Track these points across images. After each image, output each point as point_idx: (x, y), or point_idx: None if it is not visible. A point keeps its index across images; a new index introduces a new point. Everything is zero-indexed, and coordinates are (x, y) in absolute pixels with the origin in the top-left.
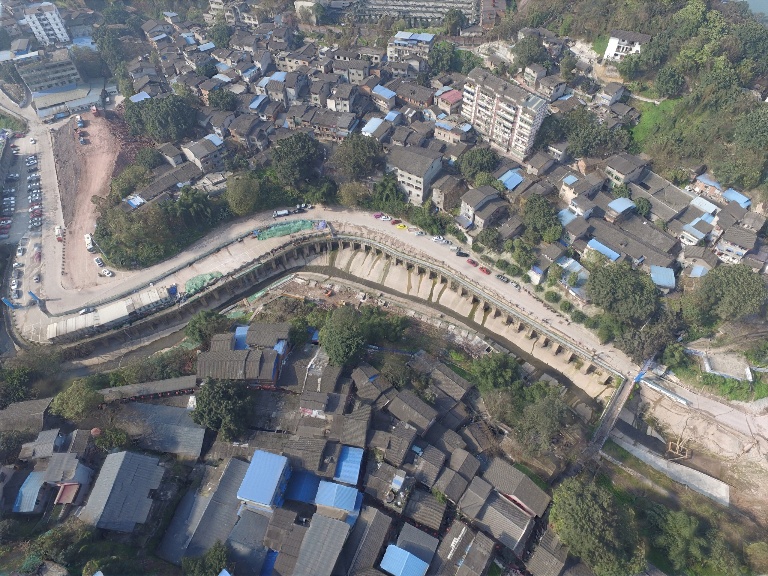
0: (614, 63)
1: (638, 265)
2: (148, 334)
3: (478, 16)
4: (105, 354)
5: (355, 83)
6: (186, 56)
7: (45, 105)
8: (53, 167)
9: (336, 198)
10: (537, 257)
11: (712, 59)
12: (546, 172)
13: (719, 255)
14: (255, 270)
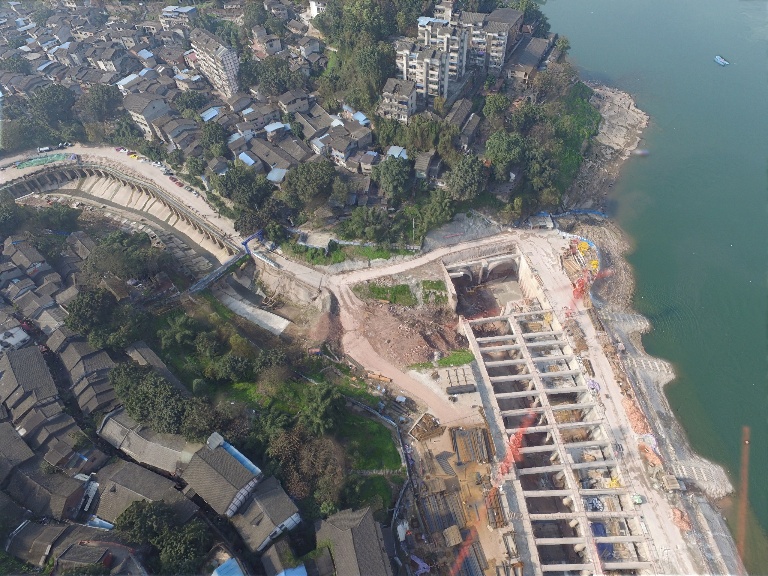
0: (311, 21)
1: None
2: None
3: None
4: None
5: None
6: (1, 33)
7: None
8: None
9: (87, 136)
10: None
11: None
12: (243, 109)
13: (338, 161)
14: (8, 190)
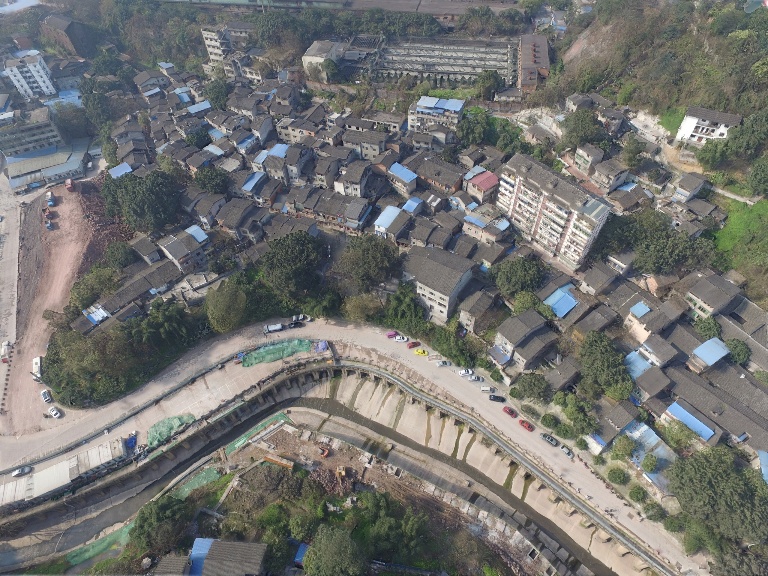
0: (692, 148)
1: (738, 443)
2: (97, 500)
3: (515, 72)
4: (40, 530)
5: (369, 158)
6: (175, 122)
7: (19, 173)
8: (16, 255)
9: (340, 311)
10: (597, 418)
11: None
12: (605, 291)
13: None
14: (236, 409)
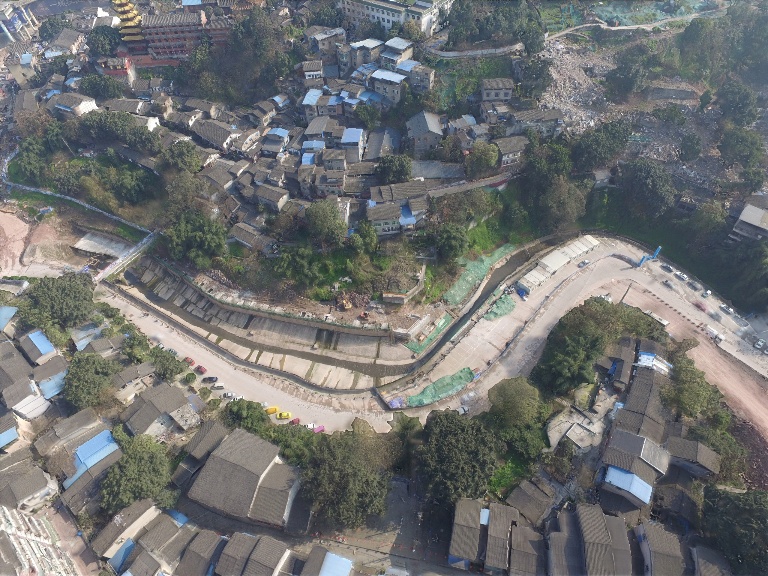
0: None
1: None
2: None
3: None
4: None
5: None
6: None
7: None
8: None
9: None
10: None
11: None
12: None
13: None
14: None
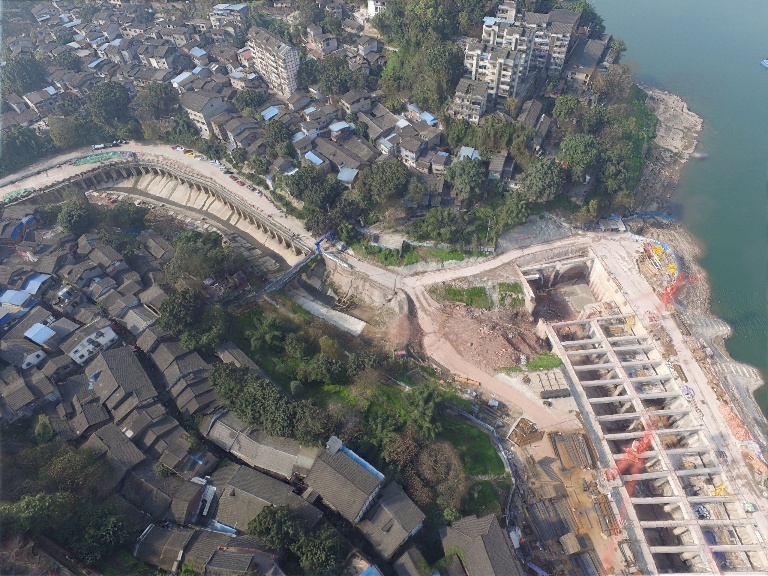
0: (370, 20)
1: None
2: None
3: None
4: None
5: None
6: (49, 29)
7: None
8: None
9: (142, 134)
10: None
11: (426, 11)
12: (303, 107)
13: (406, 161)
14: (65, 187)
